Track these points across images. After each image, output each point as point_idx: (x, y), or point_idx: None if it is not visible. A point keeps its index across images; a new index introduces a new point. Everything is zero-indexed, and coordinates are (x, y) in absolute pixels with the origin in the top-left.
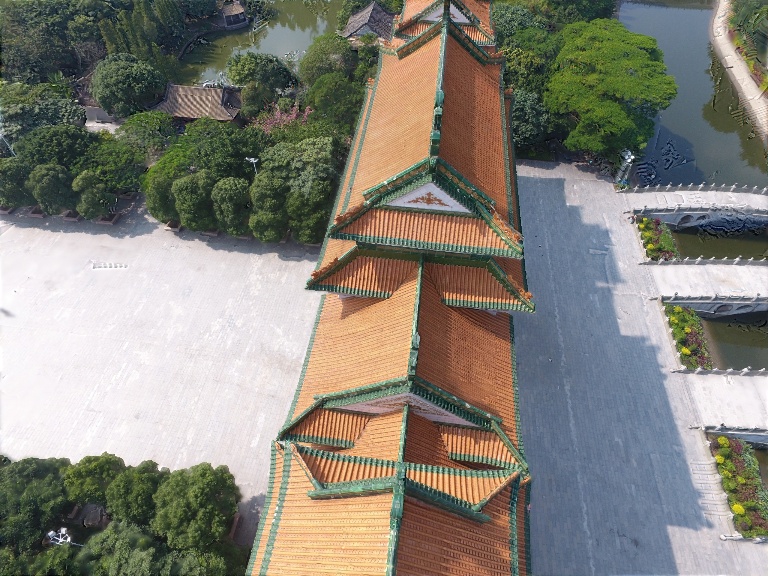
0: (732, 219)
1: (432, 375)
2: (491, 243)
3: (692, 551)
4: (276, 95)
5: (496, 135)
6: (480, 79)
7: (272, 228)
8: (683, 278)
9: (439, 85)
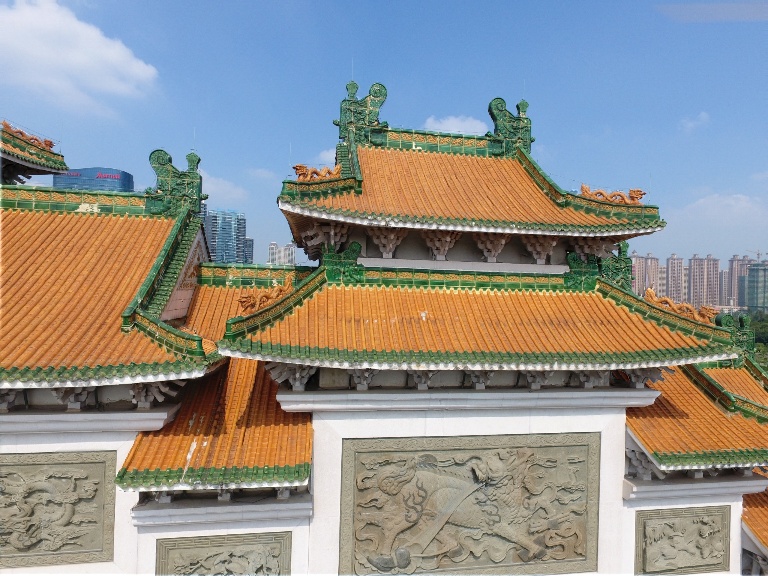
0: None
1: None
2: None
3: None
4: None
5: None
6: None
7: None
8: None
9: None
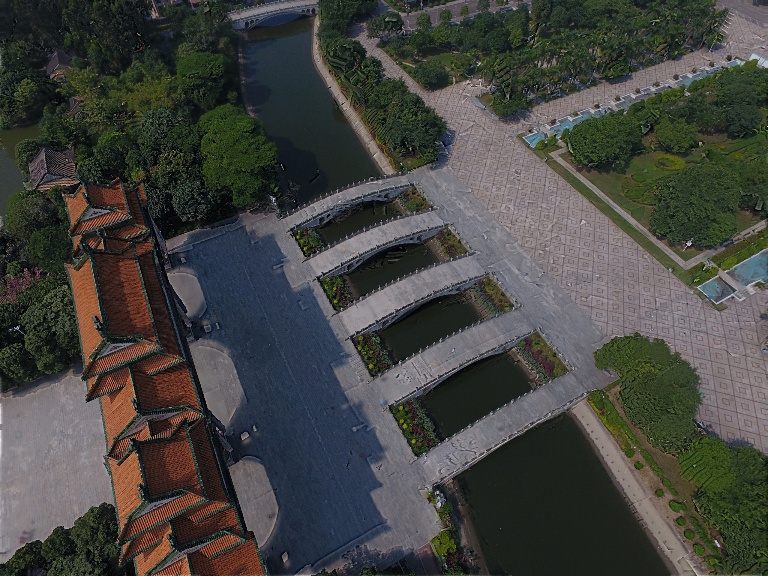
0: (344, 209)
1: (151, 406)
2: (149, 349)
3: (357, 396)
4: (2, 262)
5: (140, 294)
6: (123, 266)
7: (58, 363)
8: (326, 260)
9: (97, 299)
